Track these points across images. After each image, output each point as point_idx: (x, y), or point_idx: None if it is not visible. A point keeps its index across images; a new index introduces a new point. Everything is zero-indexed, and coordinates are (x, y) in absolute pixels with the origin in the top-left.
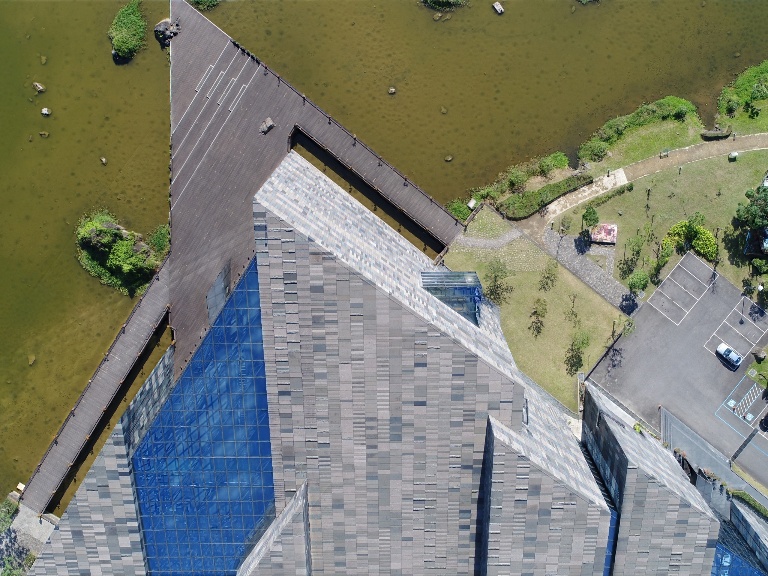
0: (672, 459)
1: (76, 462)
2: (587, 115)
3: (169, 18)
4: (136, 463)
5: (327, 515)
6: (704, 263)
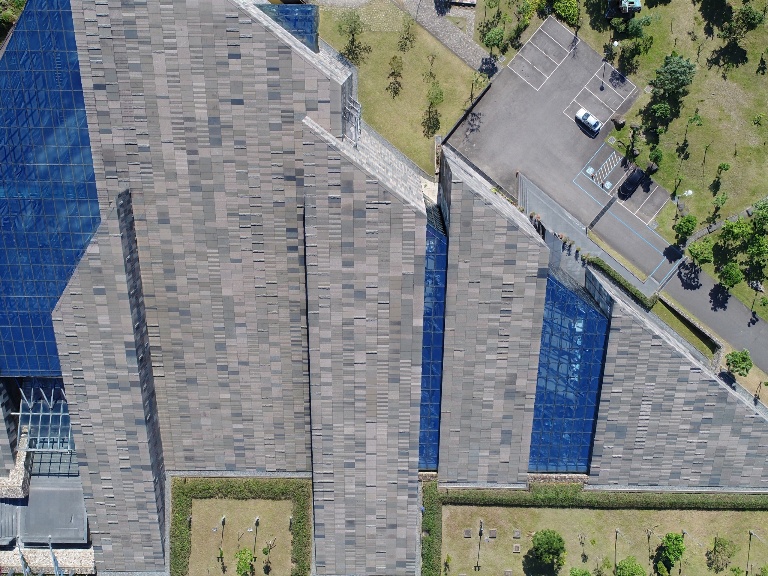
0: (523, 216)
1: None
2: None
3: None
4: None
5: (154, 231)
6: (565, 28)
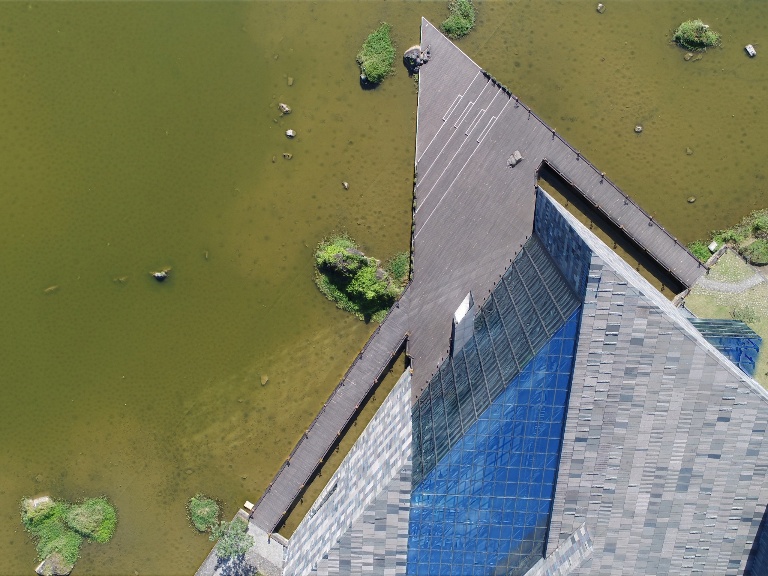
0: None
1: (306, 484)
2: None
3: (419, 45)
4: (413, 498)
5: (596, 558)
6: None
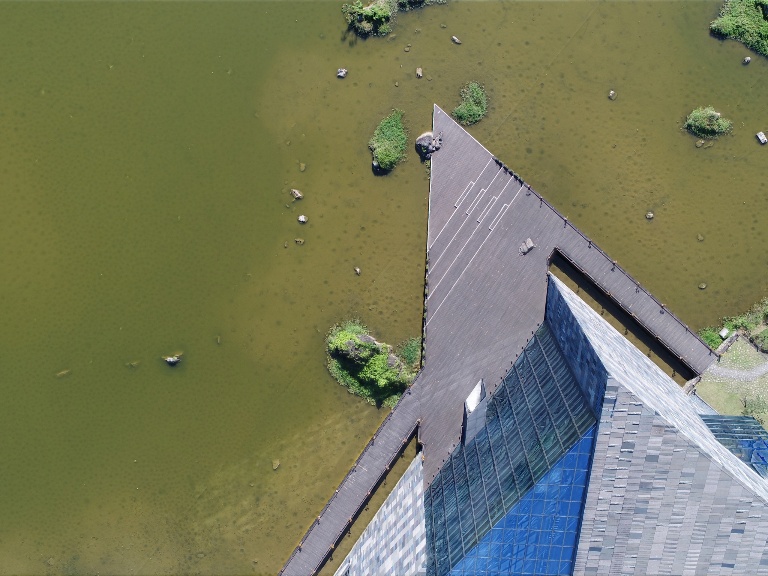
0: None
1: (317, 569)
2: None
3: (431, 132)
4: None
5: None
6: None
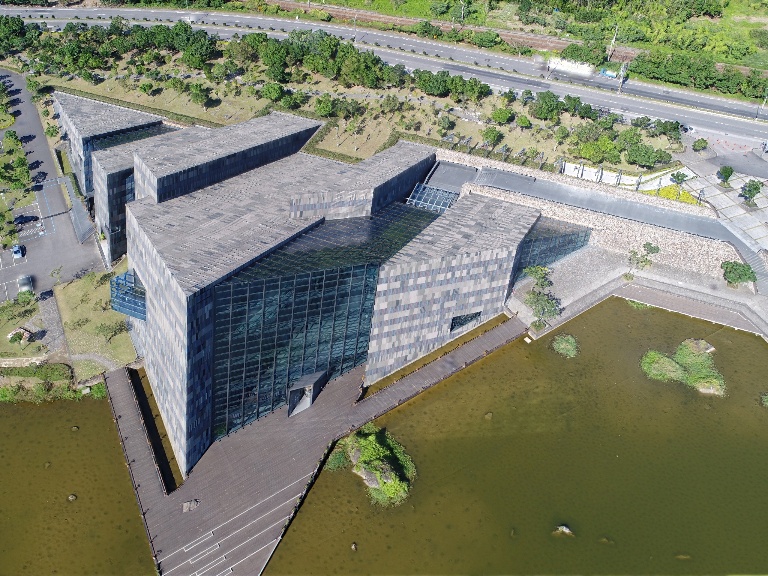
0: None
1: None
2: None
3: None
4: None
5: None
6: None
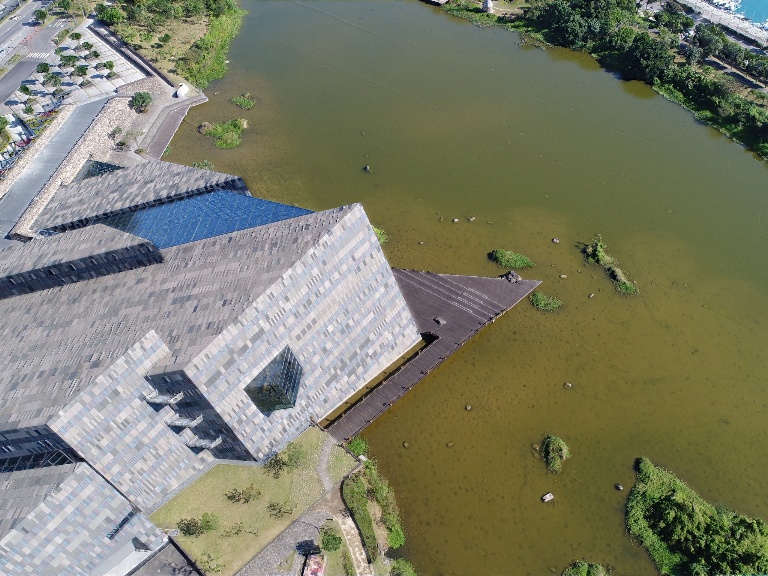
0: None
1: None
2: (442, 573)
3: None
4: None
5: (135, 277)
6: None
